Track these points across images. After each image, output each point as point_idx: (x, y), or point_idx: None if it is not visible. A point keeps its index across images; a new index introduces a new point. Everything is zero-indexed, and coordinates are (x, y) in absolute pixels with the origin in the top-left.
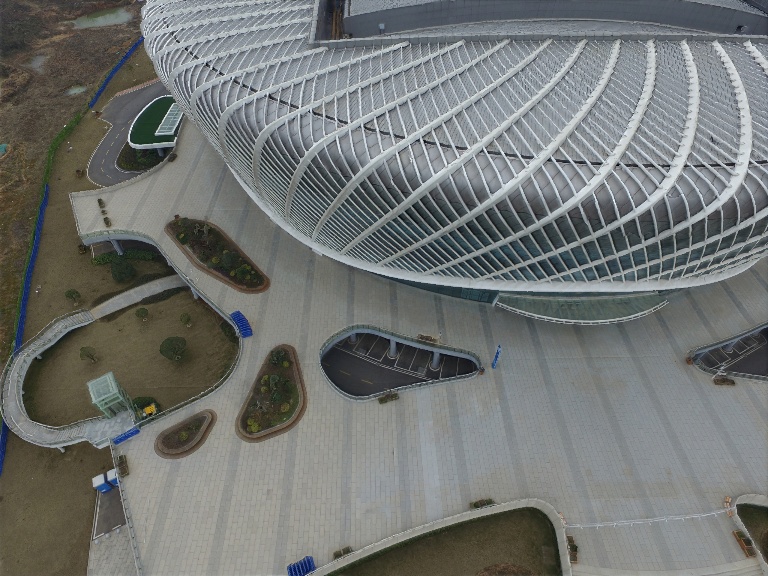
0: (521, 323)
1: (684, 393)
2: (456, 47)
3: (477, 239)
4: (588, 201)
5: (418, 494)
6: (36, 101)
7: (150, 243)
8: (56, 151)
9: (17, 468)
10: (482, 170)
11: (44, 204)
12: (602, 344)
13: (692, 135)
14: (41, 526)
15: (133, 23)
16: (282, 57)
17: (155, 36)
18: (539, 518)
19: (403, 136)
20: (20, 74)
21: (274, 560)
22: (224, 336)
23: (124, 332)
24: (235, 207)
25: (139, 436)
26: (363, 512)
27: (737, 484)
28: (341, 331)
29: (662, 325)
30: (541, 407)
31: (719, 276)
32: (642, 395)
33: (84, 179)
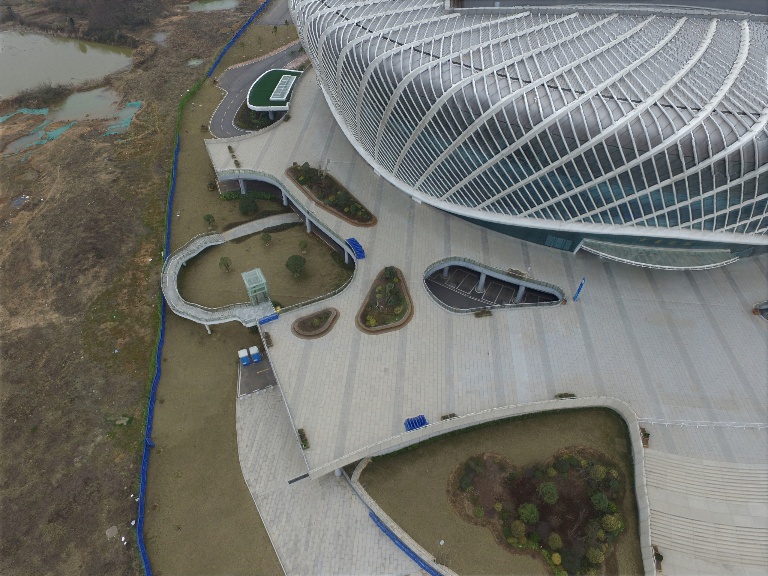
0: (599, 269)
1: (749, 336)
2: (571, 18)
3: (580, 175)
4: (686, 139)
5: (510, 385)
6: (162, 69)
7: (273, 183)
8: (183, 110)
9: (175, 341)
10: (597, 109)
11: (177, 150)
12: (674, 292)
13: None
14: (198, 382)
15: (240, 9)
16: (422, 20)
17: (307, 3)
18: (613, 417)
19: (529, 81)
20: (148, 46)
21: (393, 416)
22: (334, 262)
23: (251, 252)
24: (343, 160)
25: (278, 321)
26: (464, 392)
27: None
28: (441, 260)
29: (731, 282)
30: (617, 334)
31: None
32: (710, 334)
33: (208, 133)
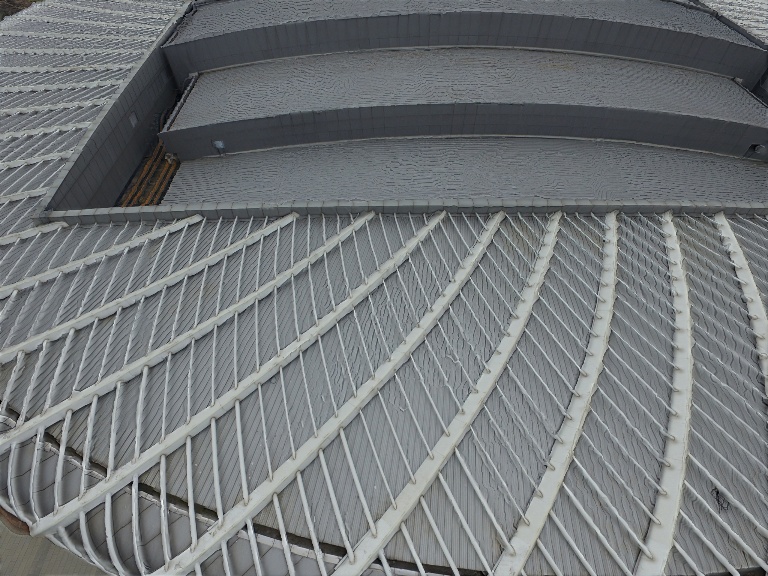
0: None
1: None
2: (277, 229)
3: None
4: None
5: None
6: None
7: None
8: None
9: None
10: None
11: None
12: None
13: (676, 495)
14: None
15: None
16: None
17: None
18: None
19: None
20: None
21: None
22: None
23: None
24: None
25: None
26: None
27: None
28: None
29: None
30: None
31: None
32: None
33: None
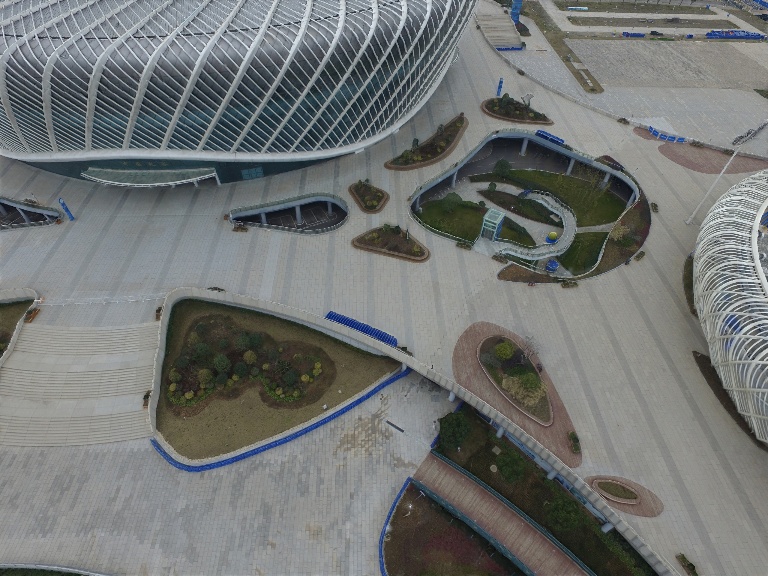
0: (118, 195)
1: (204, 236)
2: None
3: None
4: None
5: None
6: None
7: None
8: None
9: None
10: None
11: None
12: (170, 208)
13: None
14: None
15: None
16: None
17: None
18: None
19: None
20: None
21: None
22: None
23: None
24: None
25: None
26: None
27: (190, 284)
28: None
29: (228, 197)
30: (86, 243)
31: (257, 155)
32: (170, 237)
33: None
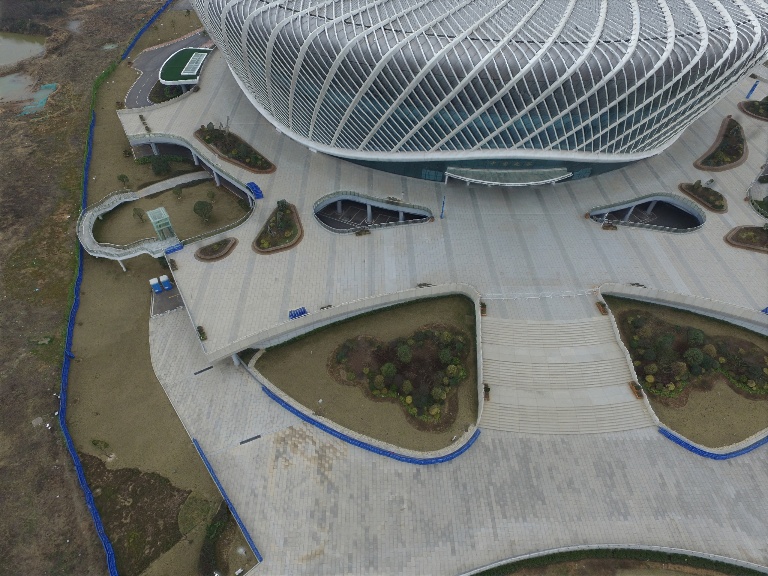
0: (465, 194)
1: (579, 234)
2: None
3: (423, 104)
4: (491, 65)
5: (380, 282)
6: (77, 53)
7: (182, 144)
8: (98, 89)
9: (93, 278)
10: (421, 45)
11: (93, 124)
12: (524, 206)
13: (562, 24)
14: (114, 308)
15: None
16: None
17: None
18: (465, 301)
19: (370, 26)
20: (61, 33)
21: (280, 312)
22: (241, 208)
23: (164, 205)
24: (248, 122)
25: (183, 250)
26: (342, 290)
27: (605, 280)
28: (330, 194)
29: (571, 196)
30: (473, 240)
31: (611, 156)
32: (548, 234)
33: None
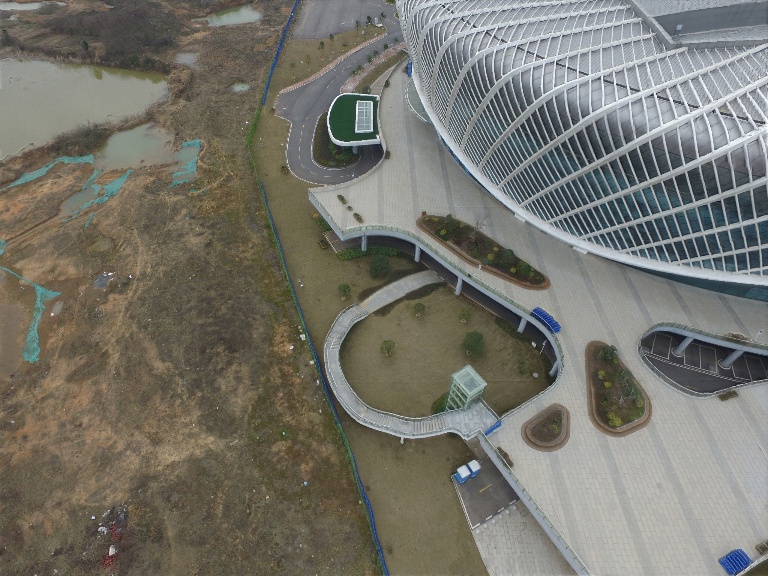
0: None
1: None
2: None
3: None
4: None
5: None
6: (208, 97)
7: (407, 239)
8: (250, 147)
9: (367, 458)
10: None
11: (266, 199)
12: None
13: None
14: (419, 515)
15: (266, 21)
16: (644, 57)
17: (466, 35)
18: None
19: None
20: (181, 71)
21: (700, 552)
22: (503, 332)
23: (403, 326)
24: (474, 205)
25: (503, 428)
26: (762, 507)
27: None
28: (650, 328)
29: None
30: None
31: None
32: None
33: (290, 175)
